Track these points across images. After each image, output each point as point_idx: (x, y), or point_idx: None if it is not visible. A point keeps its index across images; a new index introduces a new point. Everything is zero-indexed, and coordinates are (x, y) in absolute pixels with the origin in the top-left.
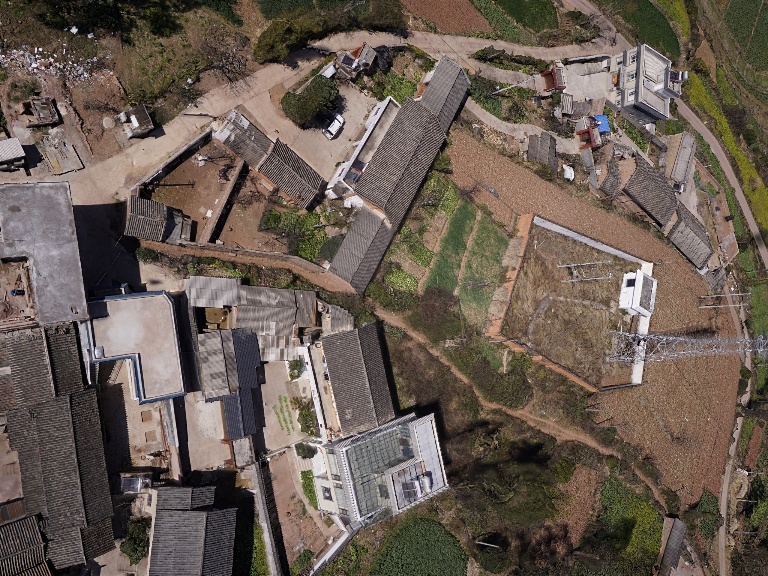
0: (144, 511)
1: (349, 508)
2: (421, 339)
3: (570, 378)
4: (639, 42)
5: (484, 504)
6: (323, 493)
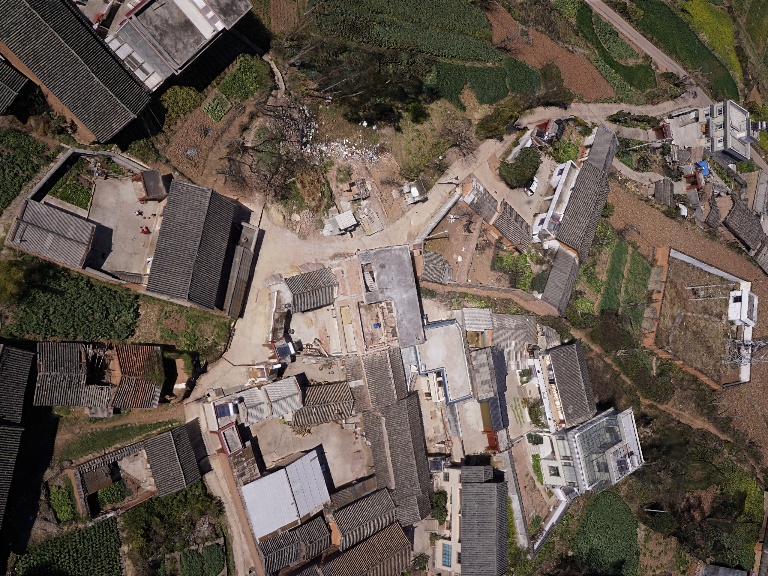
0: (440, 486)
1: (579, 480)
2: (598, 350)
3: (700, 378)
4: (713, 93)
5: (658, 478)
6: (549, 471)
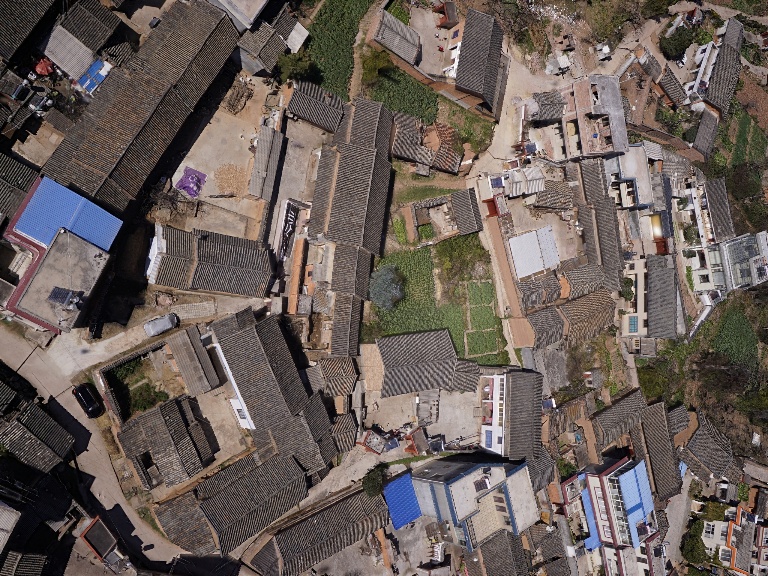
0: (625, 275)
1: (728, 282)
2: (729, 198)
3: None
4: None
5: None
6: (700, 279)
